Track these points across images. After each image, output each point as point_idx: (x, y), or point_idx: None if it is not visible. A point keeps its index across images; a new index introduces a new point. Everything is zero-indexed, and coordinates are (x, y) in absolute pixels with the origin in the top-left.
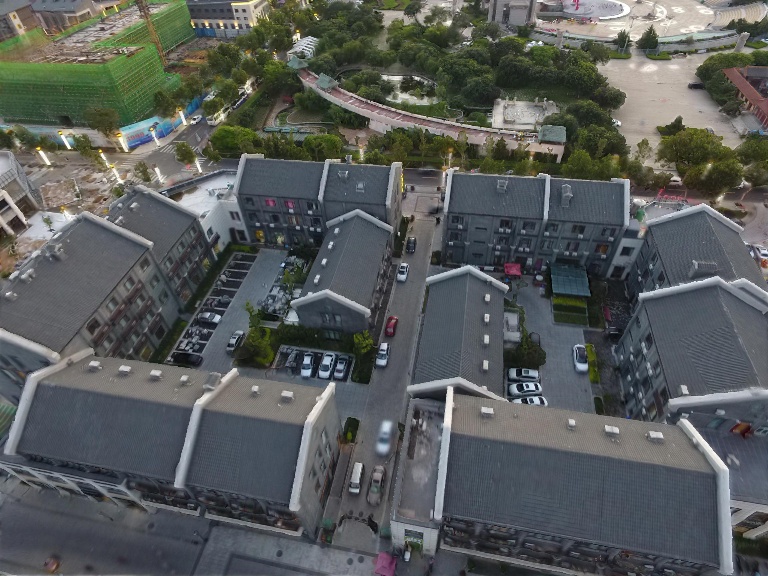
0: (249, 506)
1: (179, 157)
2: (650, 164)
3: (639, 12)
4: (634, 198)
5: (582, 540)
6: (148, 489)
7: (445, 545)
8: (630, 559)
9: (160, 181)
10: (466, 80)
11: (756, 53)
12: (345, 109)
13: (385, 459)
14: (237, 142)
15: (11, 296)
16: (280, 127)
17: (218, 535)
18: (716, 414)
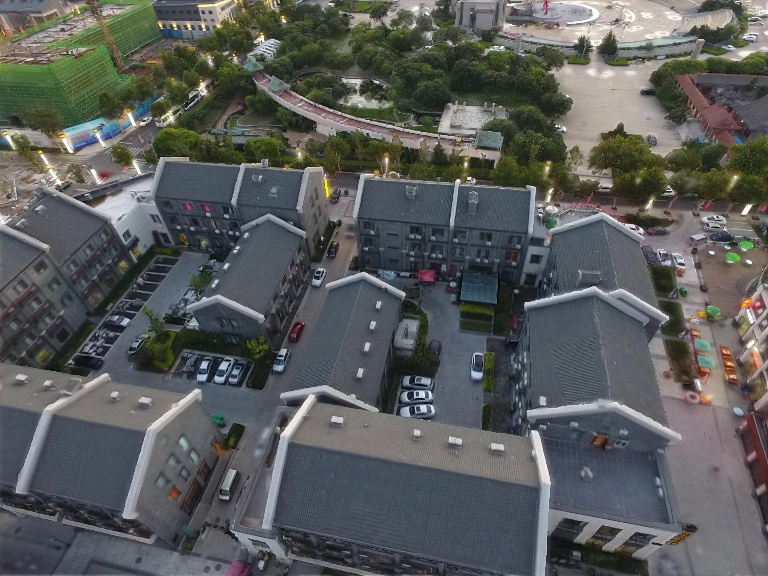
0: (95, 513)
1: (116, 159)
2: (587, 171)
3: (608, 17)
4: (564, 205)
5: (405, 553)
6: (0, 494)
7: (292, 555)
8: (459, 572)
9: (97, 183)
10: (418, 84)
11: (710, 60)
12: (294, 112)
13: None
14: None
15: None
16: (228, 129)
17: (82, 541)
18: (570, 426)
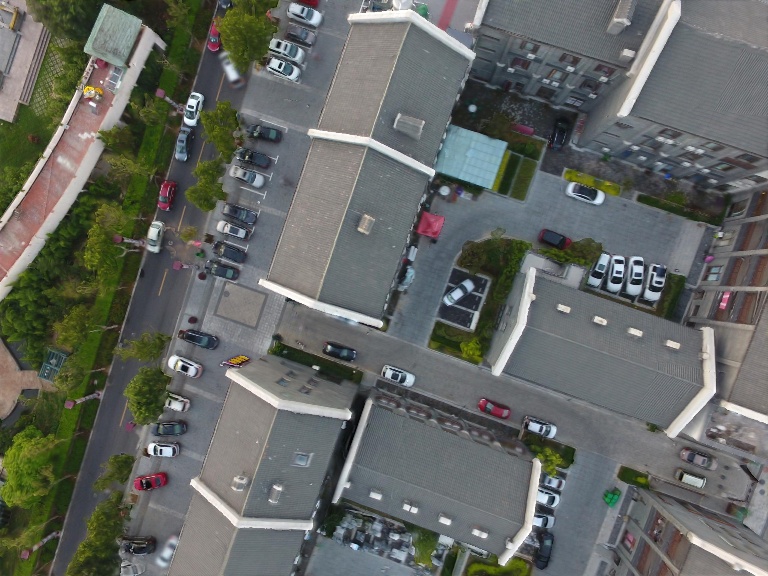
0: None
1: None
2: None
3: None
4: None
5: None
6: None
7: None
8: None
9: None
10: None
11: None
12: None
13: (671, 445)
14: None
15: None
16: None
17: None
18: None
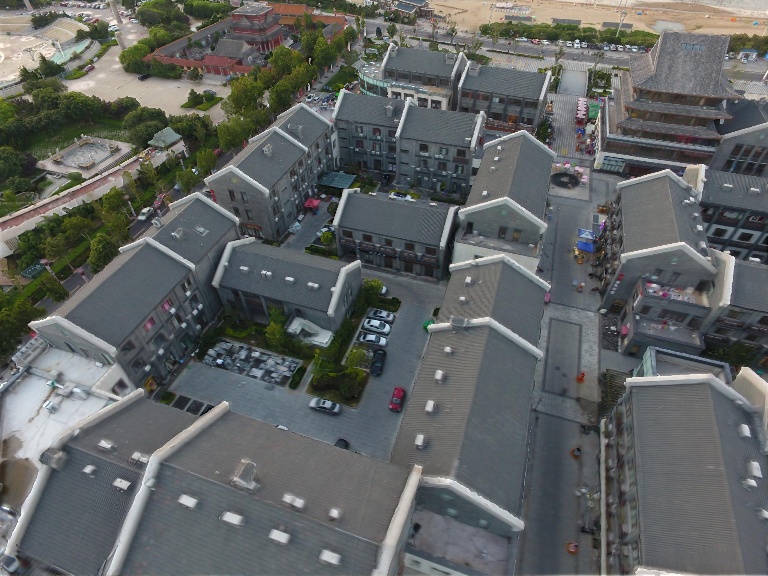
0: None
1: None
2: None
3: None
4: None
5: None
6: None
7: None
8: None
9: None
10: None
11: (142, 42)
12: None
13: None
14: None
15: None
16: None
17: None
18: None
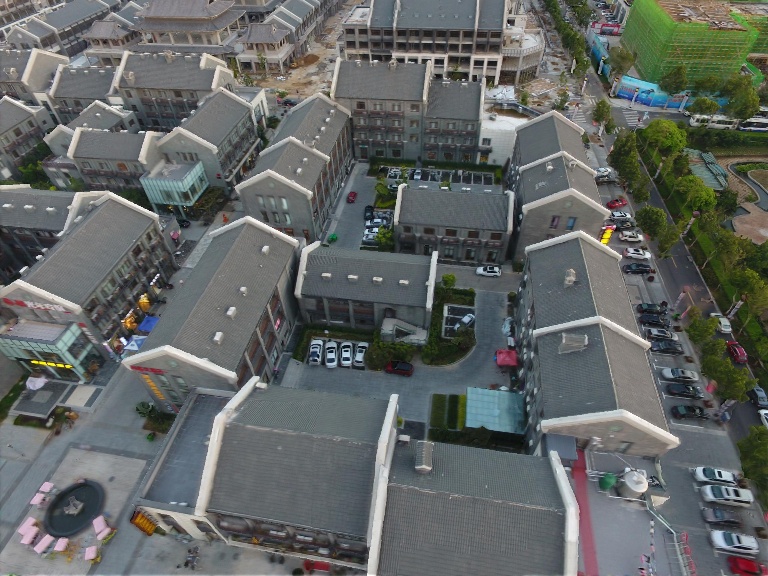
0: None
1: None
2: None
3: None
4: None
5: None
6: None
7: None
8: None
9: None
10: None
11: None
12: None
13: None
14: (650, 136)
15: (358, 64)
16: None
17: None
18: None
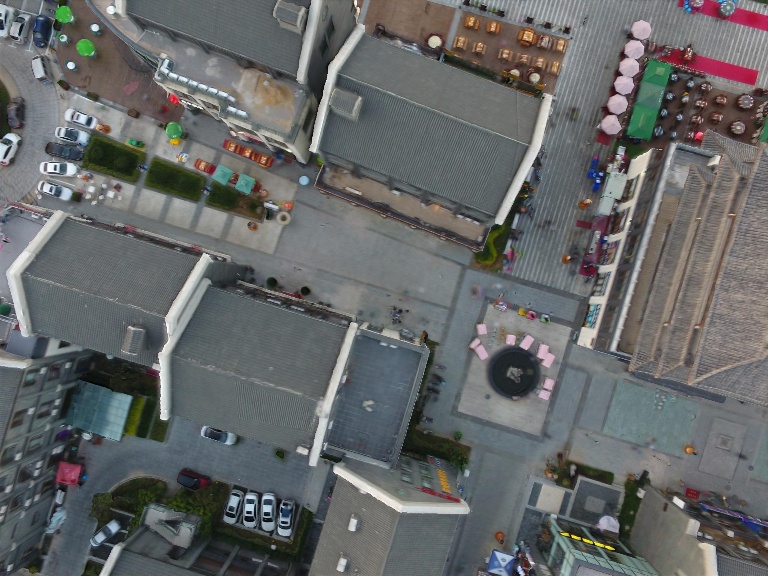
0: None
1: None
2: None
3: None
4: None
5: None
6: None
7: None
8: None
9: None
10: None
11: None
12: None
13: None
14: None
15: None
16: None
17: None
18: None
